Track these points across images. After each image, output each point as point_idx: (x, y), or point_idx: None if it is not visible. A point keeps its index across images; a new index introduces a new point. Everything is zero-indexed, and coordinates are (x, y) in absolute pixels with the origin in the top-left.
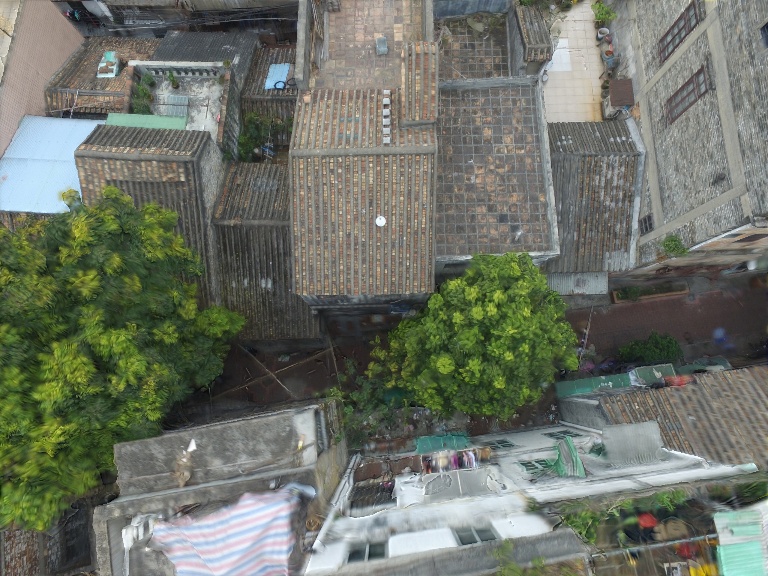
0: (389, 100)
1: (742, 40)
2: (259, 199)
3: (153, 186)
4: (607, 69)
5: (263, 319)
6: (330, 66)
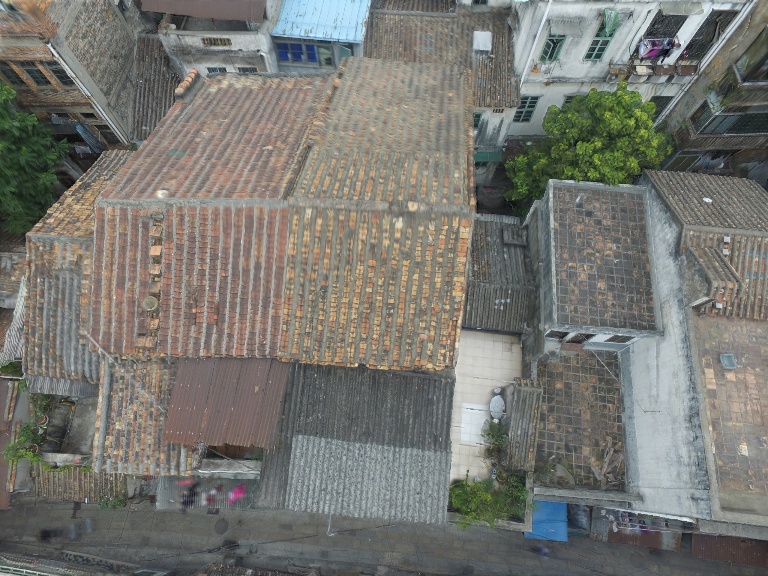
0: None
1: None
2: None
3: None
4: None
5: None
6: None
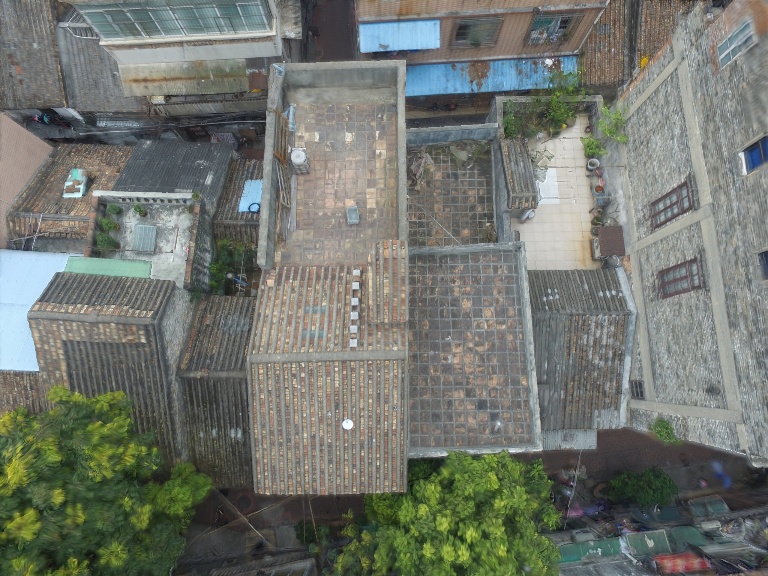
0: (359, 284)
1: (738, 256)
2: (229, 343)
3: (112, 346)
4: (597, 206)
5: (233, 468)
6: (297, 237)
